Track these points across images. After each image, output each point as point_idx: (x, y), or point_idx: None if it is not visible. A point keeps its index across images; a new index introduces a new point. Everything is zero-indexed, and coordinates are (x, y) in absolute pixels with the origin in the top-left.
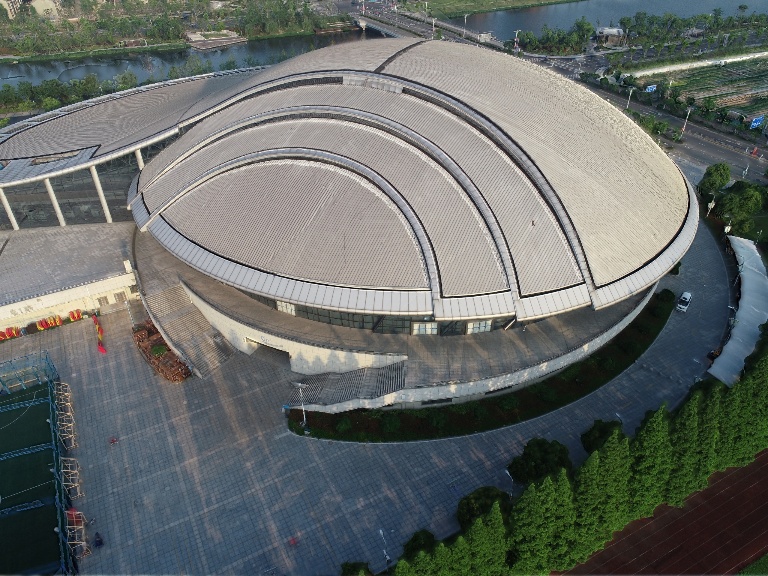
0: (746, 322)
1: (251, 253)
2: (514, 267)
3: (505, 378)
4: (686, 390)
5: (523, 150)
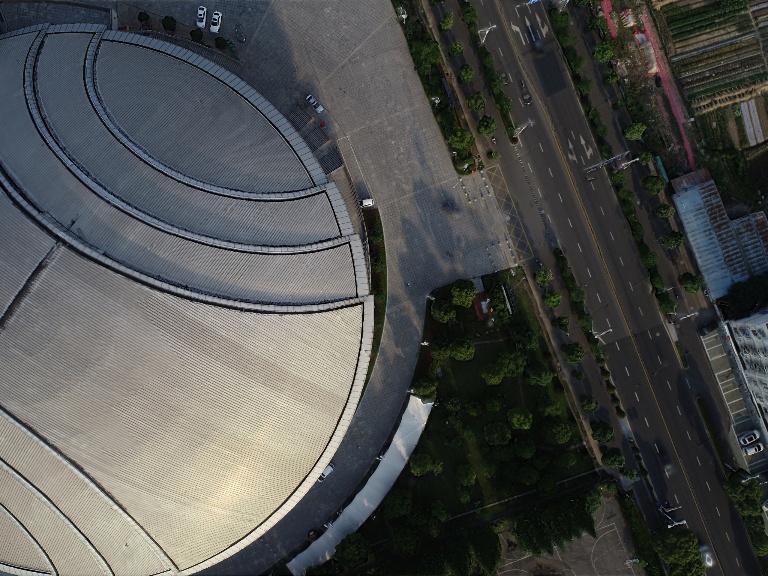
0: (348, 518)
1: None
2: (111, 570)
3: None
4: (276, 561)
5: (114, 501)
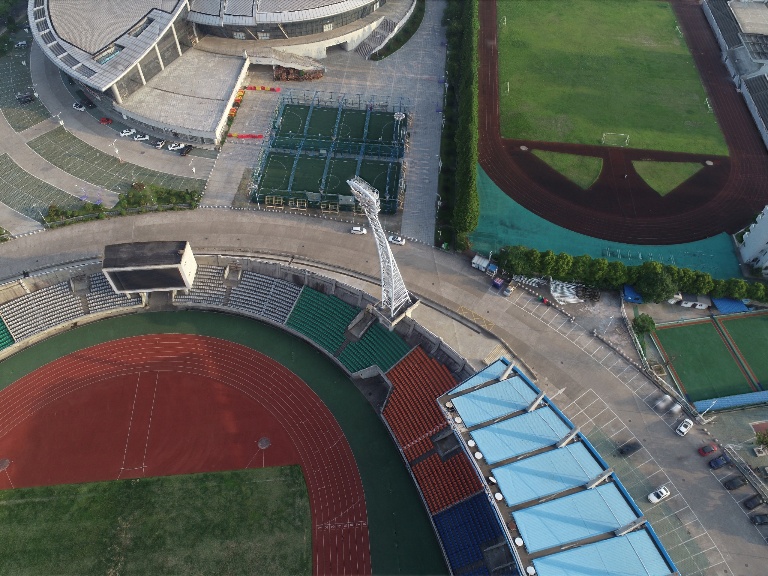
0: None
1: None
2: None
3: (413, 5)
4: None
5: None
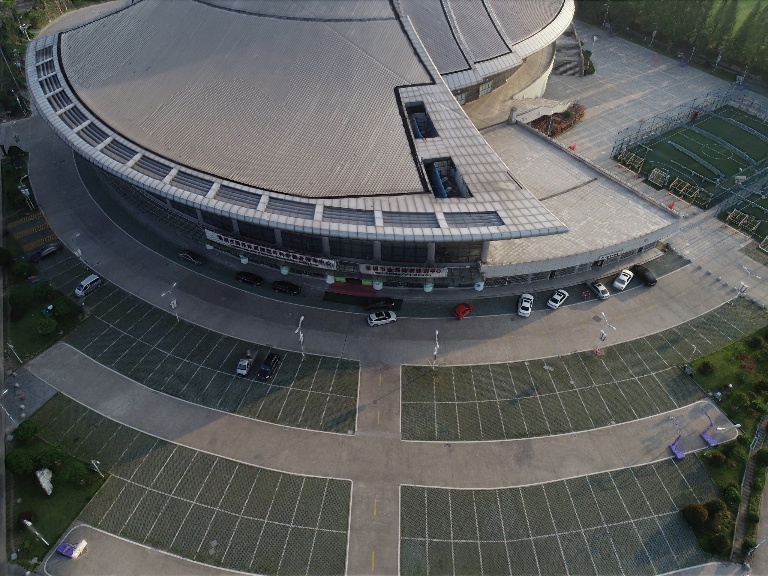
0: None
1: (553, 4)
2: None
3: None
4: None
5: None
